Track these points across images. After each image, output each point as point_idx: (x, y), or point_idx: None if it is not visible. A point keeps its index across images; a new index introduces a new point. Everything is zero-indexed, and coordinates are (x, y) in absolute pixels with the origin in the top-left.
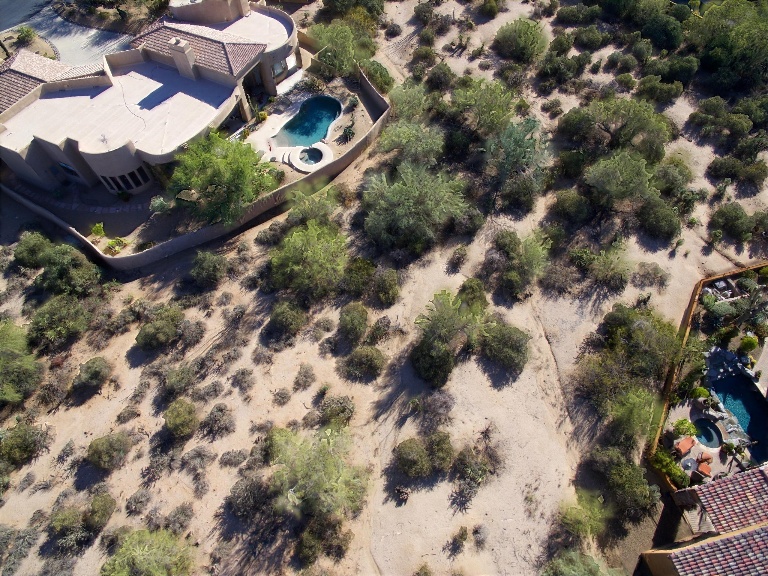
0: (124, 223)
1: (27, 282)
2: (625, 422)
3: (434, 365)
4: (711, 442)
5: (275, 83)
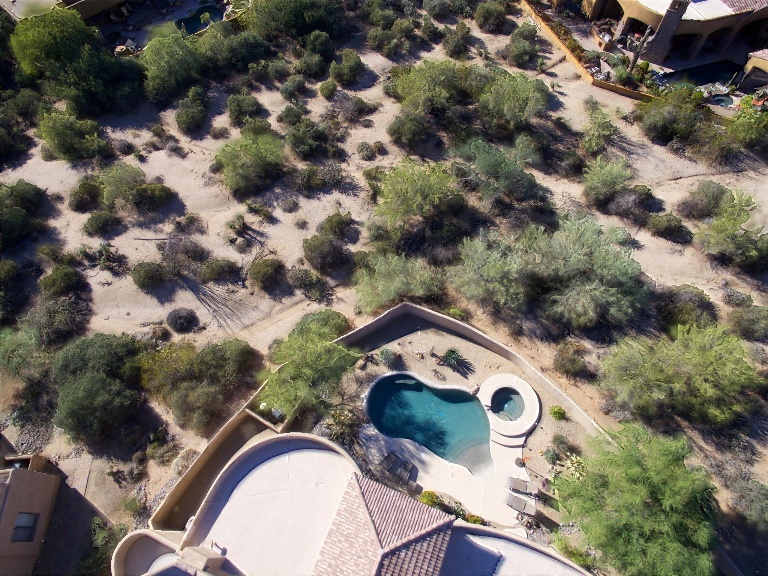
0: None
1: None
2: None
3: None
4: (725, 101)
5: None
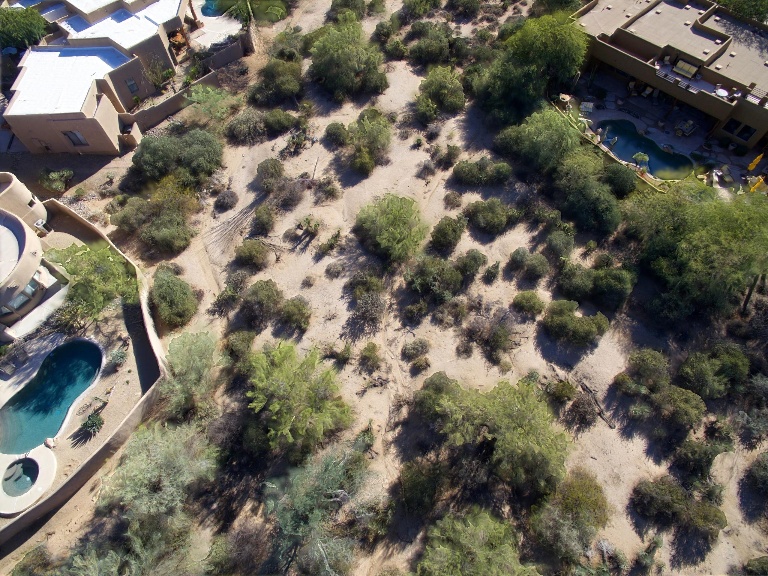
0: None
1: None
2: None
3: None
4: None
5: (18, 317)
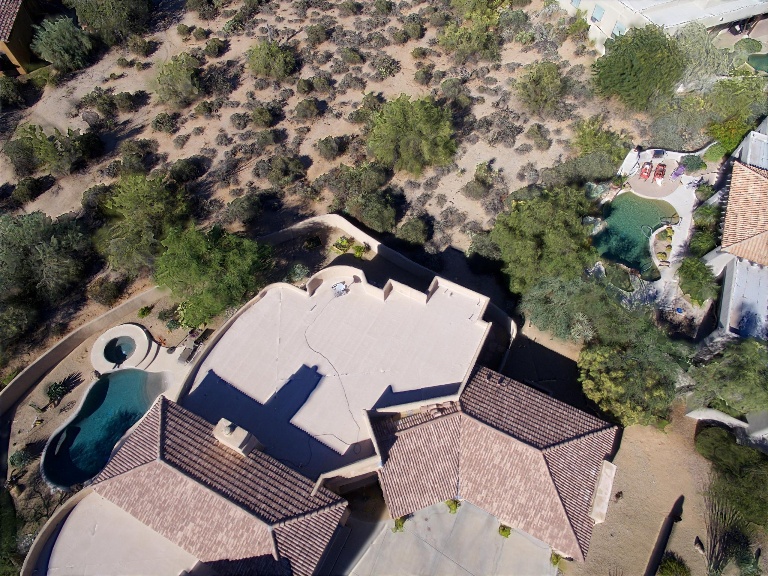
0: None
1: (411, 212)
2: None
3: None
4: None
5: None
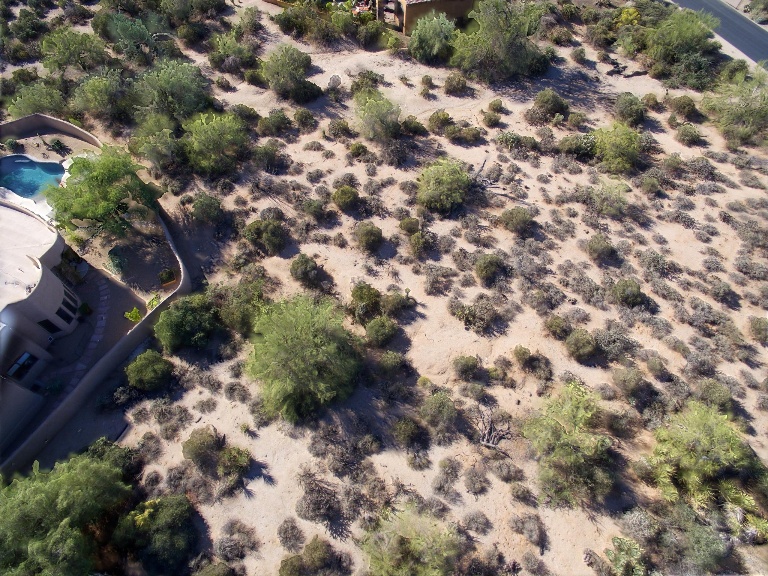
0: (125, 308)
1: None
2: (347, 21)
3: (310, 85)
4: None
5: None
